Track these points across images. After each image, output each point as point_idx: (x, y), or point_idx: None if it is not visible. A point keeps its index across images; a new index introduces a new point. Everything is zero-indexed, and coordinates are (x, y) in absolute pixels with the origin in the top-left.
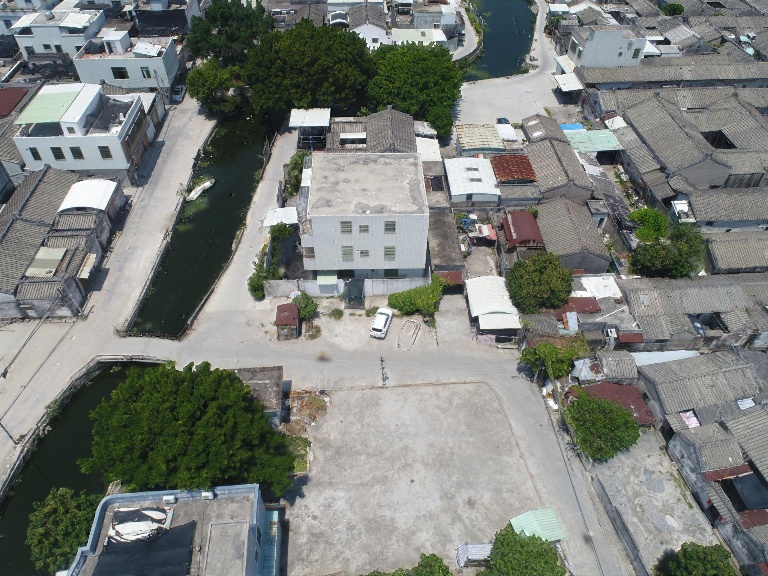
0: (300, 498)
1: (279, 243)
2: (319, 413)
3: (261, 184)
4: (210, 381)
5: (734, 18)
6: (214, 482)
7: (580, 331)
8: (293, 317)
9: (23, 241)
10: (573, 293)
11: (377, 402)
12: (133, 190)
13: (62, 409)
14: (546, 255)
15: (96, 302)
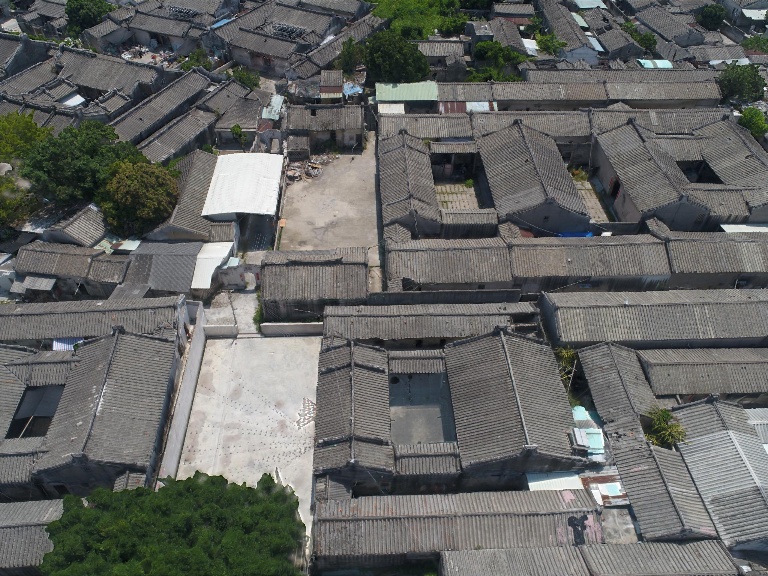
0: None
1: None
2: None
3: None
4: None
5: (596, 568)
6: None
7: None
8: None
9: None
10: None
11: None
12: None
13: None
14: None
15: None
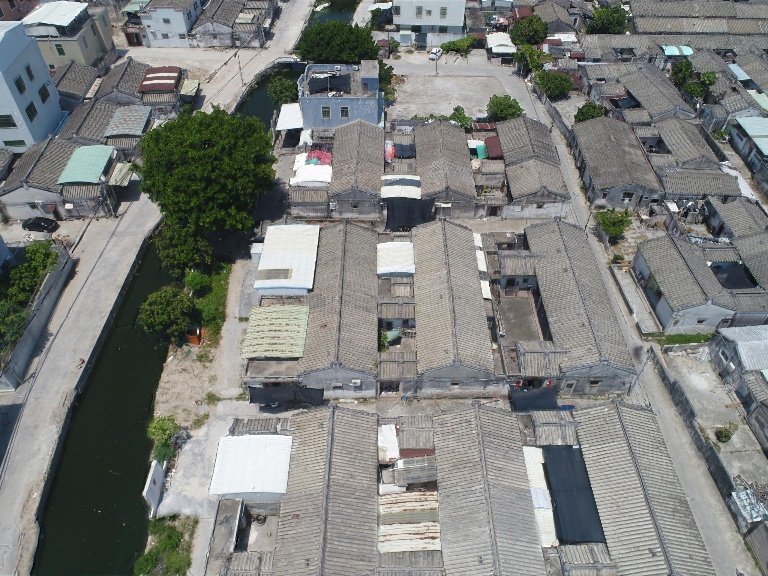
0: (392, 106)
1: (377, 17)
2: (401, 82)
3: (361, 4)
4: (356, 25)
5: None
6: (358, 62)
7: (550, 54)
8: (387, 44)
9: (231, 8)
10: (548, 37)
11: (432, 81)
12: (281, 4)
13: (261, 81)
14: (534, 15)
15: (271, 44)
